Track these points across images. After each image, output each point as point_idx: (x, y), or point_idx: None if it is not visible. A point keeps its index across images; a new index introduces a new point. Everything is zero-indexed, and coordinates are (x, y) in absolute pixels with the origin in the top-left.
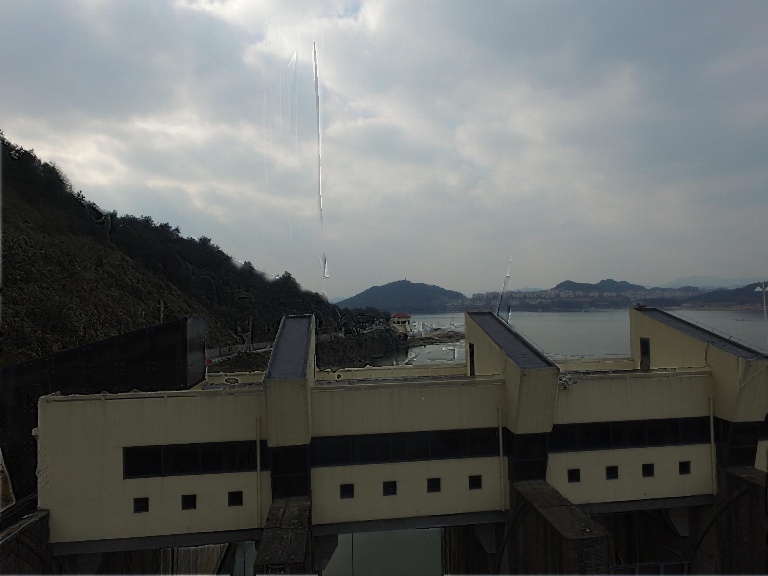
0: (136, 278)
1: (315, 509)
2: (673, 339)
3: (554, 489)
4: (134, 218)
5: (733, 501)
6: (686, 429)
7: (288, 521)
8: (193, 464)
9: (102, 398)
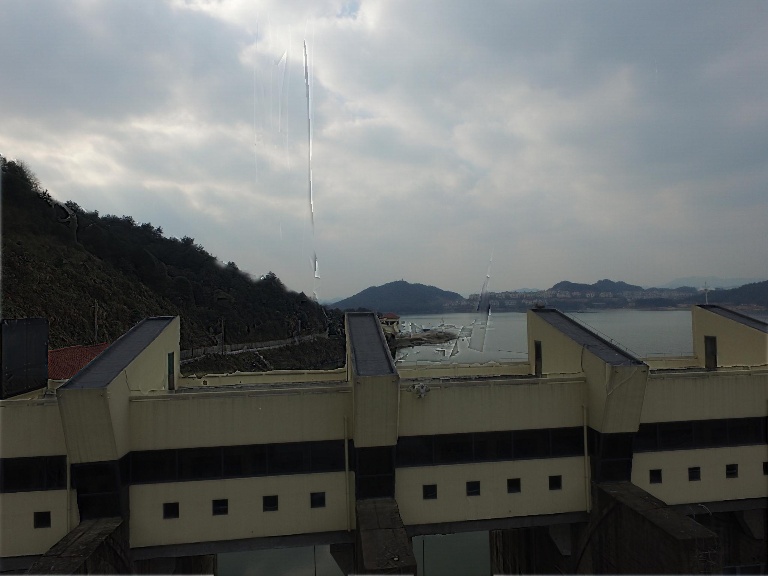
0: (101, 278)
1: (134, 530)
2: (558, 342)
3: (396, 508)
4: (116, 218)
5: (603, 519)
6: (558, 440)
7: (75, 547)
8: None
9: None
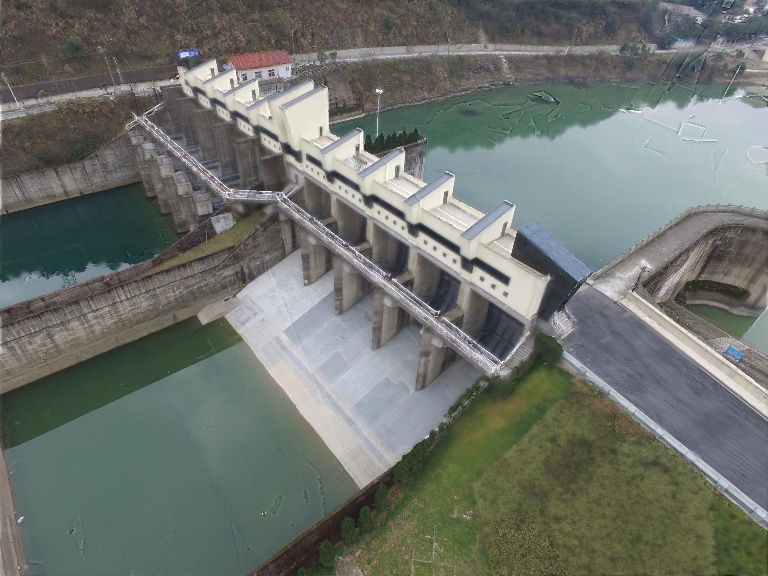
0: None
1: (199, 100)
2: None
3: (211, 109)
4: None
5: None
6: None
7: (187, 97)
8: None
9: None
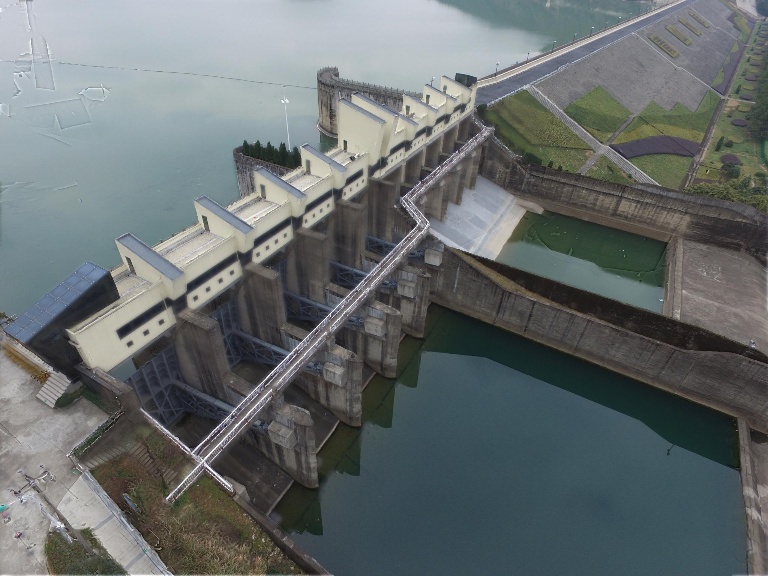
0: None
1: None
2: (275, 188)
3: (257, 264)
4: None
5: (298, 240)
6: (285, 223)
7: (195, 317)
8: (142, 321)
9: (101, 320)
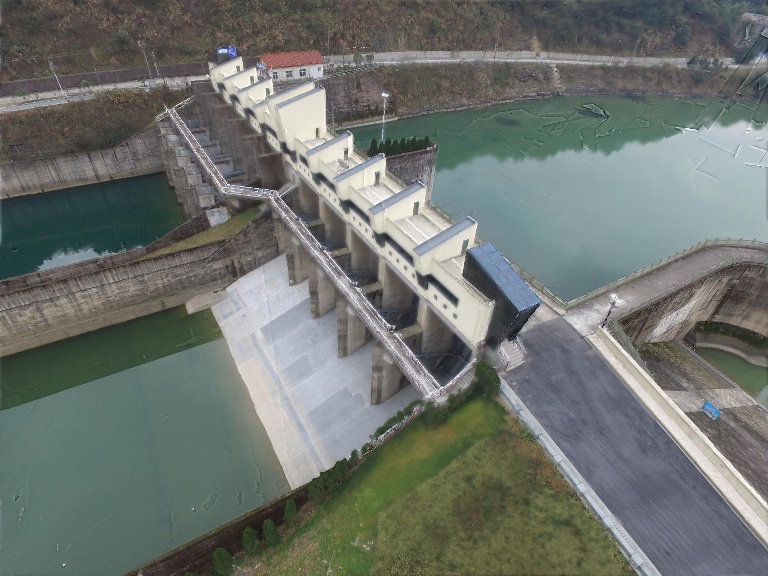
0: None
1: None
2: None
3: (230, 105)
4: None
5: None
6: None
7: None
8: None
9: None
